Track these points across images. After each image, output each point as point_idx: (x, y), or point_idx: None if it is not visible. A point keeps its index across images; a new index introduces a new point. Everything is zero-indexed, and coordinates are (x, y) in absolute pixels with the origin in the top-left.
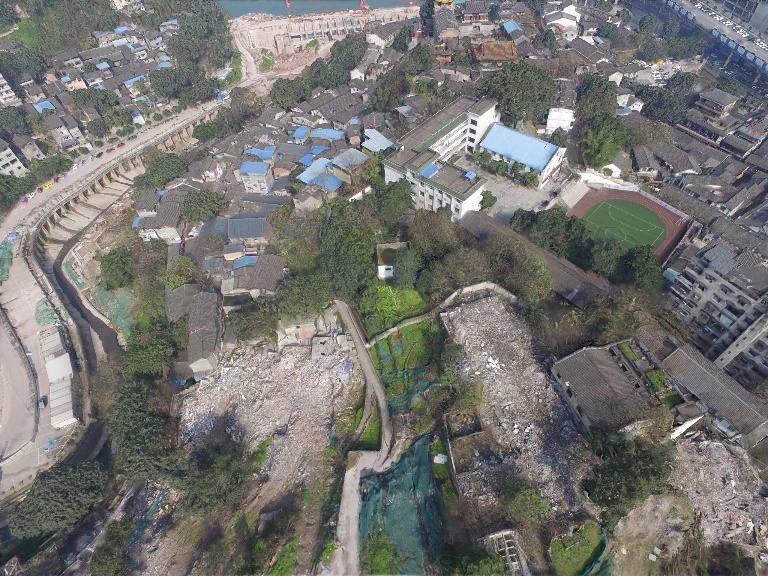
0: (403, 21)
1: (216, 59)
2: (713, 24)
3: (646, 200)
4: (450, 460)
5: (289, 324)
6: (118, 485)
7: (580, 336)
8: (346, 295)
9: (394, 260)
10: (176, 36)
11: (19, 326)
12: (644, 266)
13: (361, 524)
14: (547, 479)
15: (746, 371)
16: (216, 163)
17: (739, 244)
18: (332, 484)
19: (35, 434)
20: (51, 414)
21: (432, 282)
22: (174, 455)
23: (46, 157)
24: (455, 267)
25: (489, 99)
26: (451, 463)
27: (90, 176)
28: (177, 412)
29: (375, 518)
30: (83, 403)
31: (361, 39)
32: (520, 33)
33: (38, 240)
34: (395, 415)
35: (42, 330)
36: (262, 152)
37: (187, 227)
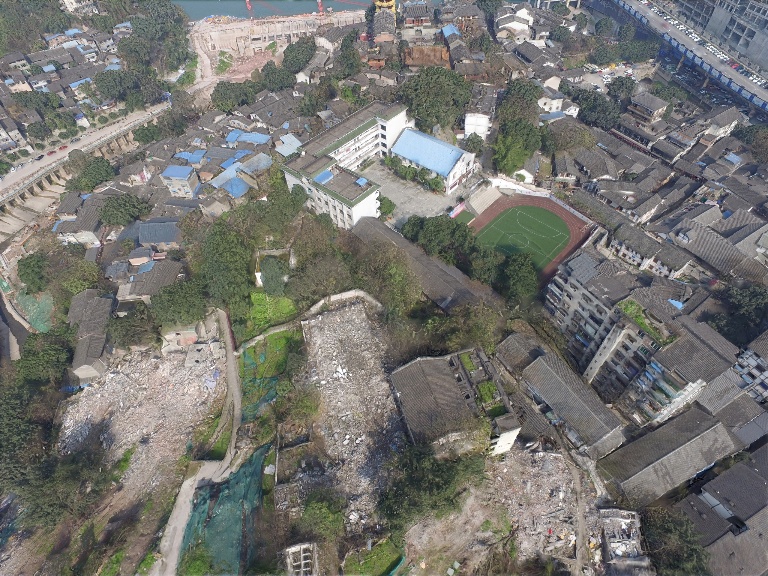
0: (357, 24)
1: (169, 61)
2: (667, 28)
3: (556, 206)
4: None
5: (168, 331)
6: None
7: (430, 345)
8: (221, 302)
9: None
10: (125, 38)
11: None
12: (518, 274)
13: (185, 535)
14: (363, 491)
15: (611, 380)
16: (143, 167)
17: (640, 251)
18: None
19: None
20: None
21: (301, 290)
22: None
23: None
24: (328, 274)
25: (399, 104)
26: None
27: (28, 179)
28: None
29: (197, 529)
30: None
31: (310, 42)
32: (456, 37)
33: None
34: (244, 424)
35: None
36: (191, 156)
37: (107, 231)
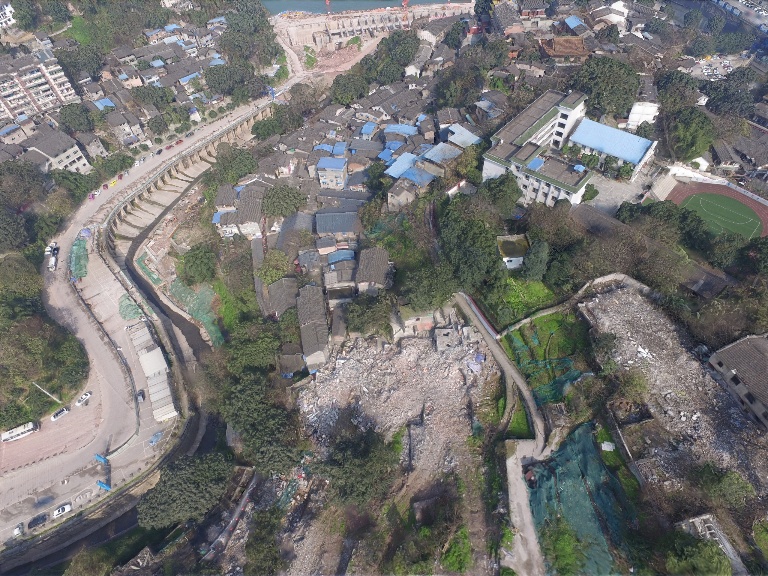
0: (449, 17)
1: (263, 56)
2: (760, 19)
3: (736, 193)
4: (623, 447)
5: (409, 316)
6: (238, 477)
7: (729, 325)
8: (471, 287)
9: (528, 251)
10: (227, 33)
11: (105, 321)
12: None
13: (534, 511)
14: (728, 465)
15: None
16: (290, 159)
17: None
18: (485, 473)
19: (138, 427)
20: (153, 408)
21: (562, 273)
22: (299, 446)
23: (108, 154)
24: (581, 259)
25: (579, 93)
26: (625, 450)
27: (153, 173)
28: (293, 404)
29: (550, 505)
30: (180, 397)
31: (413, 35)
32: (585, 28)
33: (108, 236)
34: (545, 404)
35: (128, 325)
36: (334, 148)
37: (268, 222)
